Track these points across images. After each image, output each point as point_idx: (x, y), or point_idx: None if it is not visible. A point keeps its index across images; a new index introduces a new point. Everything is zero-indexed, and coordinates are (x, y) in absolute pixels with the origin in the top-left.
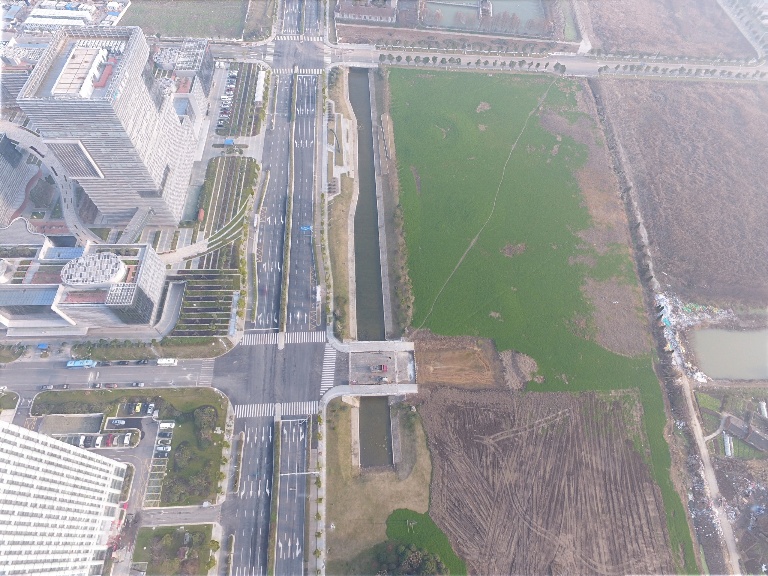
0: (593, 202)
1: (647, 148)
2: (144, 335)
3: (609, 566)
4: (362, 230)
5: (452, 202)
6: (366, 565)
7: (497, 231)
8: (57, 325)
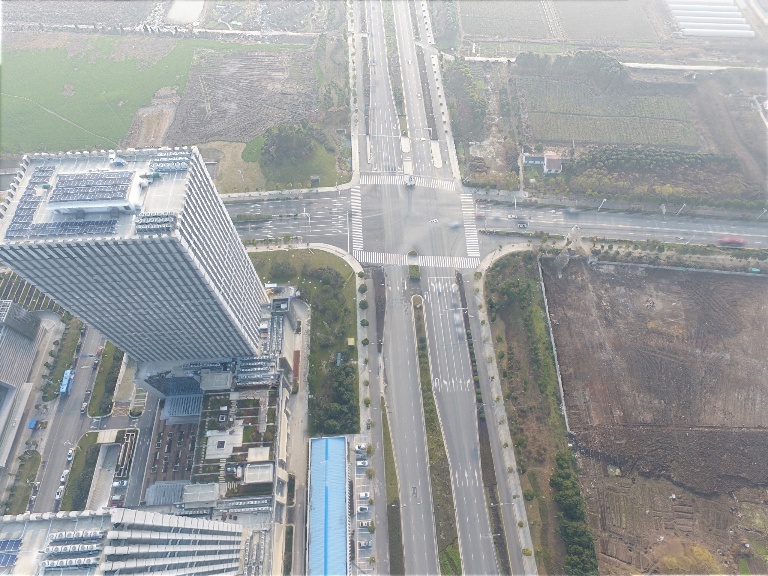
0: (44, 45)
1: (5, 9)
2: (53, 338)
3: (285, 73)
4: (2, 187)
5: (1, 122)
6: (269, 169)
7: (46, 97)
8: (10, 404)
